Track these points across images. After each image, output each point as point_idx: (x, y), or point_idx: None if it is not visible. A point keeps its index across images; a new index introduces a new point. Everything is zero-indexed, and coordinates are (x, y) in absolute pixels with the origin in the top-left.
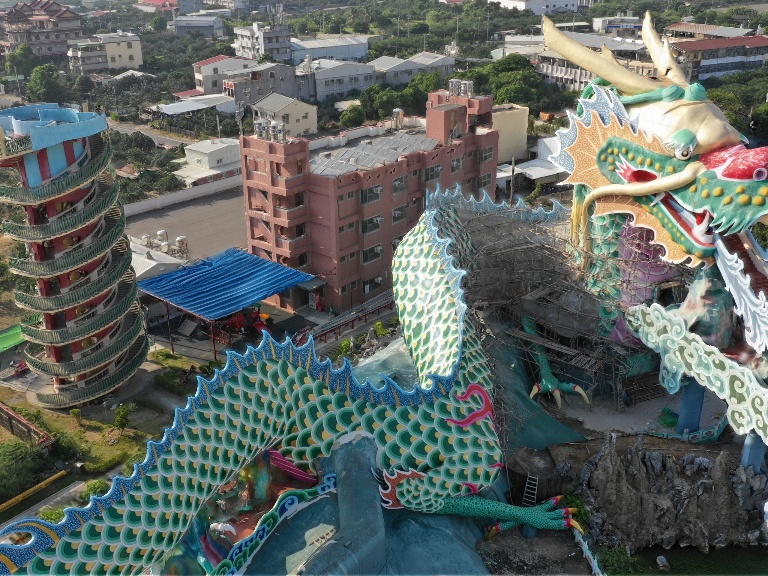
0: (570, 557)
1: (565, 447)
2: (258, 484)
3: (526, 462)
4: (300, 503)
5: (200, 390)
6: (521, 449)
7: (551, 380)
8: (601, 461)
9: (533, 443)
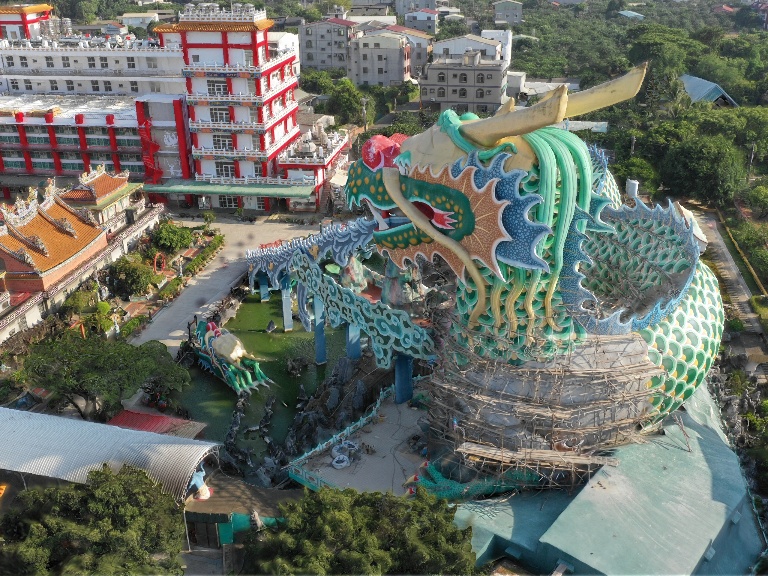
0: None
1: None
2: None
3: None
4: None
5: None
6: None
7: None
8: None
9: None
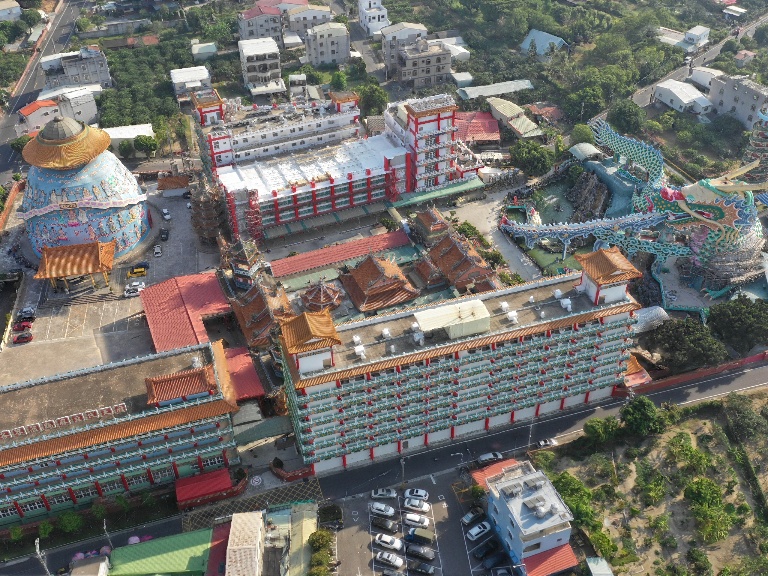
0: None
1: None
2: None
3: None
4: None
5: None
6: None
7: None
8: None
9: None
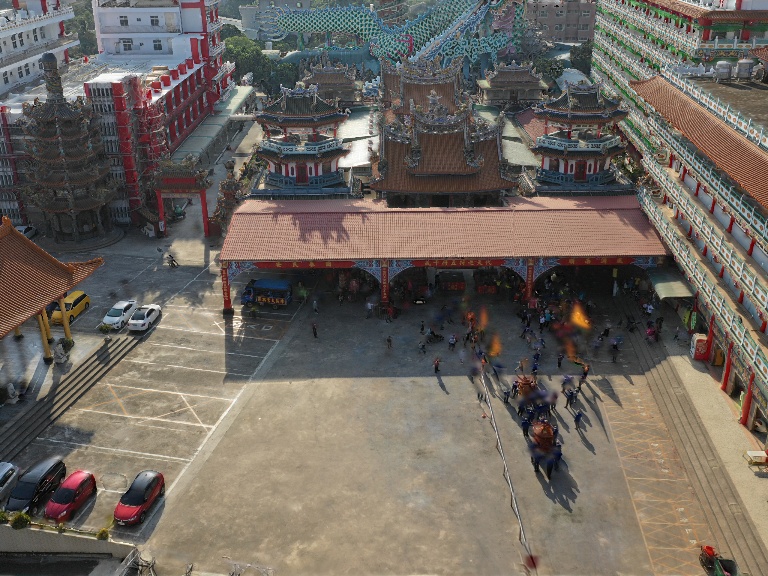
0: None
1: None
2: None
3: None
4: None
5: (338, 8)
6: None
7: None
8: None
9: None
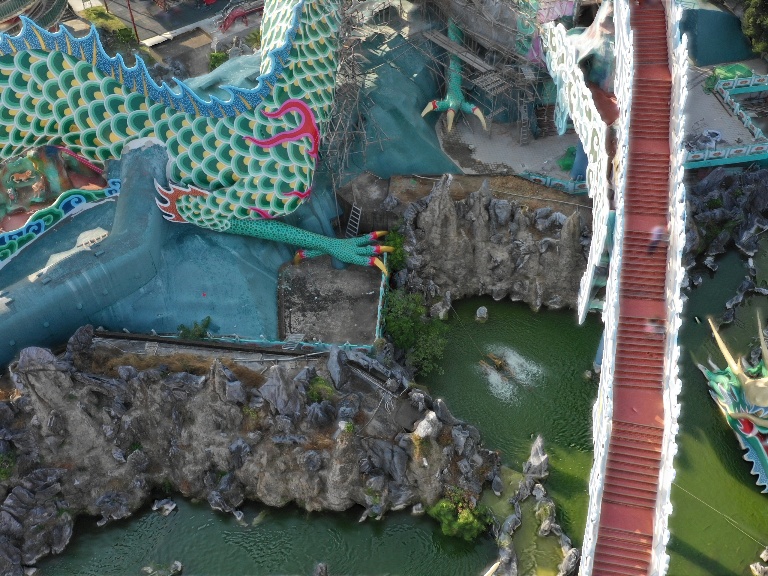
0: (366, 295)
1: (409, 180)
2: (49, 178)
3: (361, 190)
4: (87, 203)
5: None
6: (365, 175)
7: (455, 97)
8: (431, 202)
9: (389, 169)
